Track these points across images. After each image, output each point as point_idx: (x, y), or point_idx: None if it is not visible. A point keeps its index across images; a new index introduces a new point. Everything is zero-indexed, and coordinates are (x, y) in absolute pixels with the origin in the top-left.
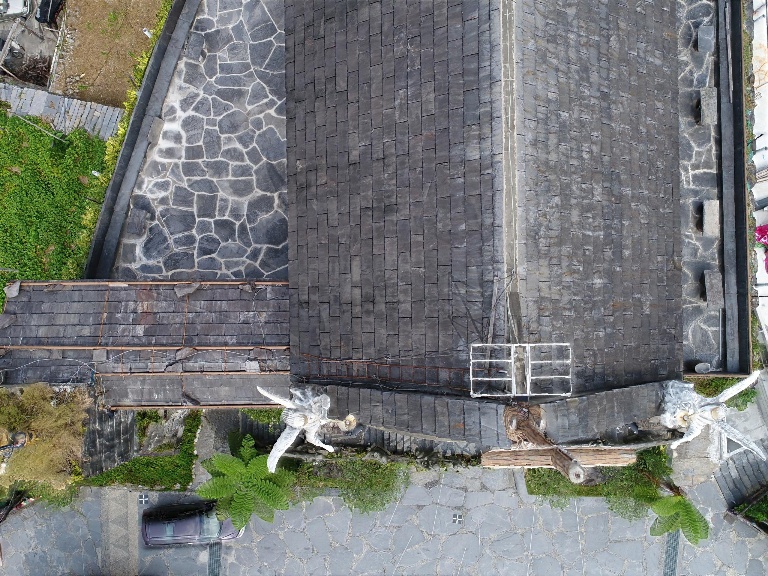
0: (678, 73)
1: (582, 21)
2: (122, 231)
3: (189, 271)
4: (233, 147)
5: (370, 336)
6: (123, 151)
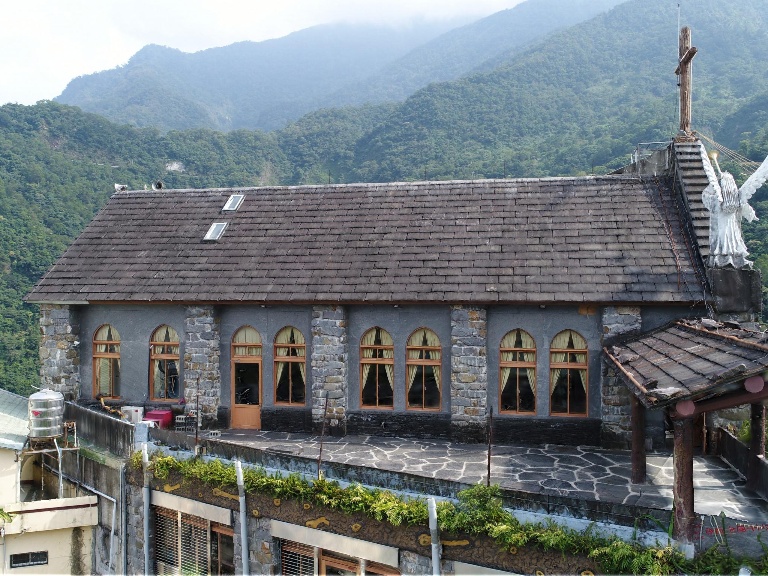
0: None
1: None
2: None
3: (598, 495)
4: (422, 467)
5: (648, 238)
6: None
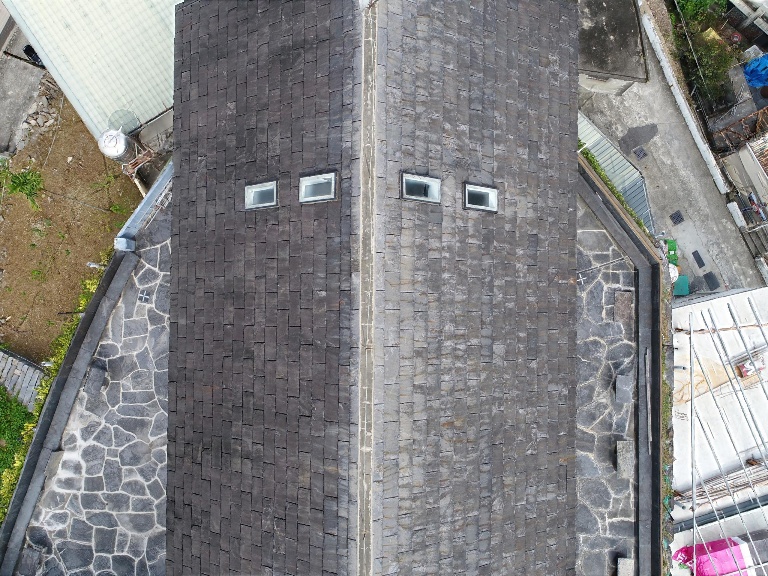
0: (597, 416)
1: (458, 504)
2: (17, 564)
3: None
4: (134, 480)
5: None
6: (17, 491)
